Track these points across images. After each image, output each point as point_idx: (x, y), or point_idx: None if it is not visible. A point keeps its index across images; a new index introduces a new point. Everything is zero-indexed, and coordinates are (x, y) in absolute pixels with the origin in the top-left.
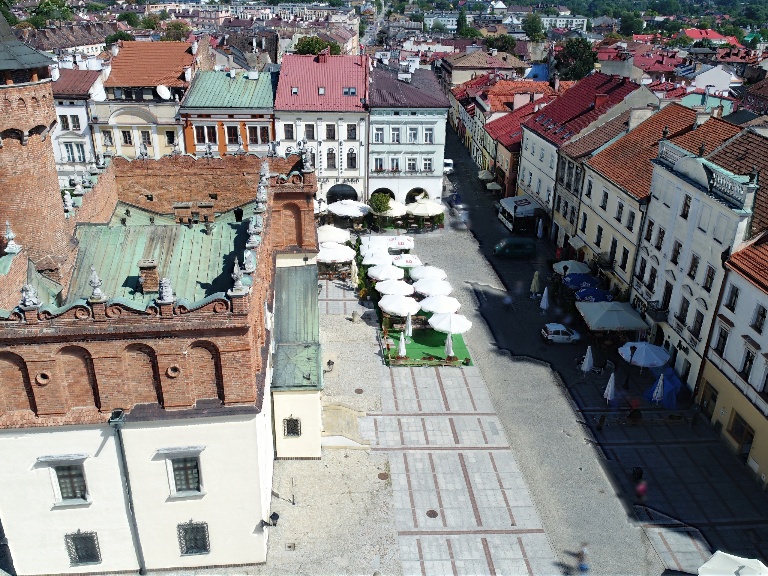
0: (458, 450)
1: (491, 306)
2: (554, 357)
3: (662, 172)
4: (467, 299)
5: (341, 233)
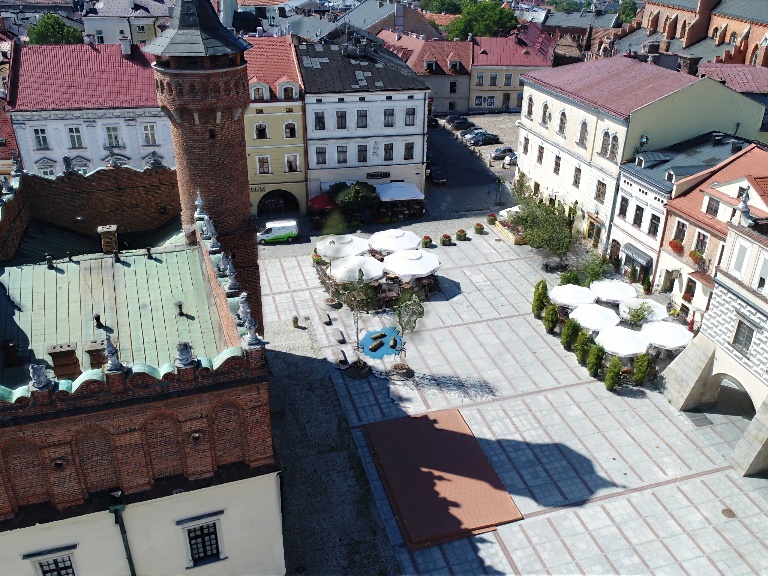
0: None
1: None
2: None
3: None
4: None
5: None
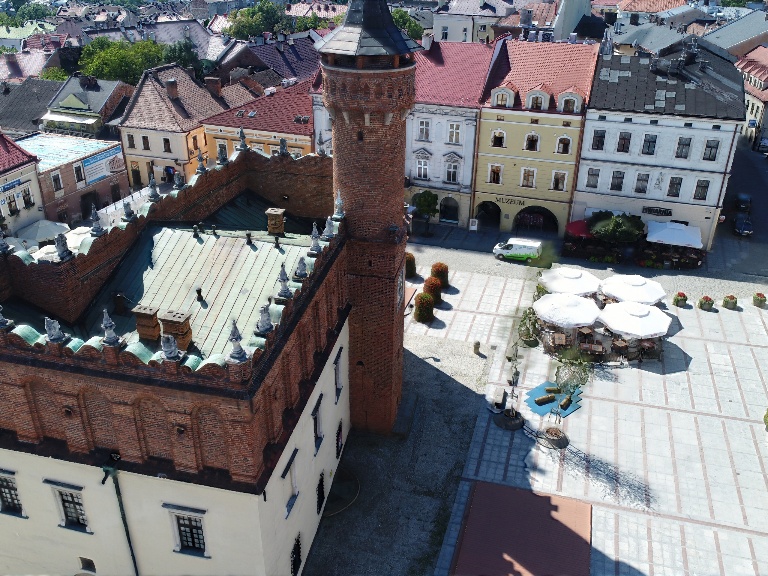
0: None
1: None
2: None
3: None
4: None
5: None
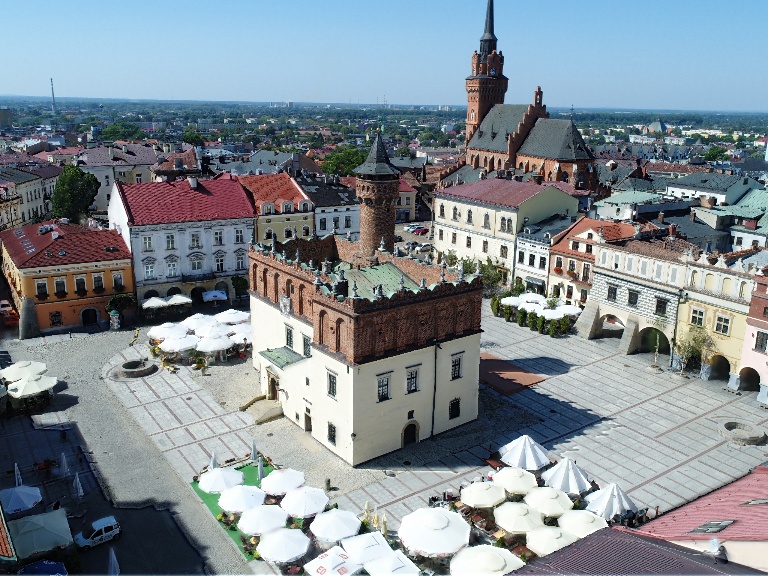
0: (184, 425)
1: (190, 571)
2: (109, 515)
3: None
4: (226, 573)
5: (468, 569)
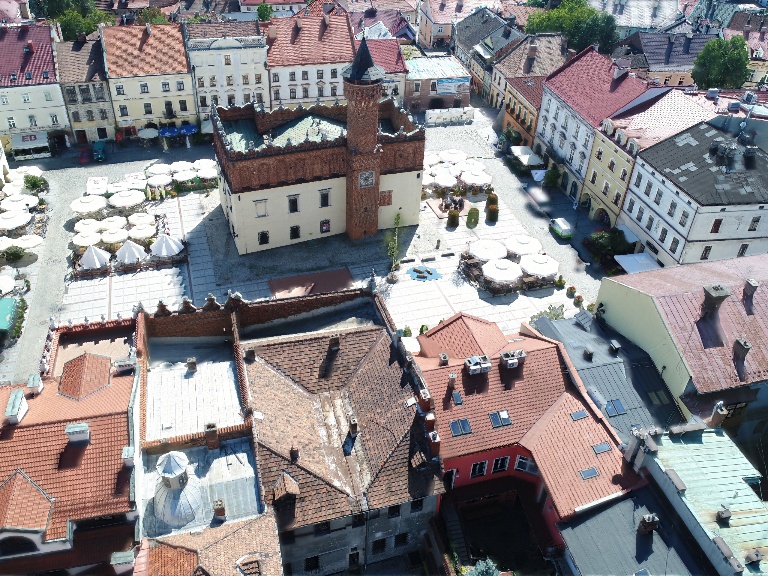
0: None
1: None
2: None
3: (200, 53)
4: None
5: None
